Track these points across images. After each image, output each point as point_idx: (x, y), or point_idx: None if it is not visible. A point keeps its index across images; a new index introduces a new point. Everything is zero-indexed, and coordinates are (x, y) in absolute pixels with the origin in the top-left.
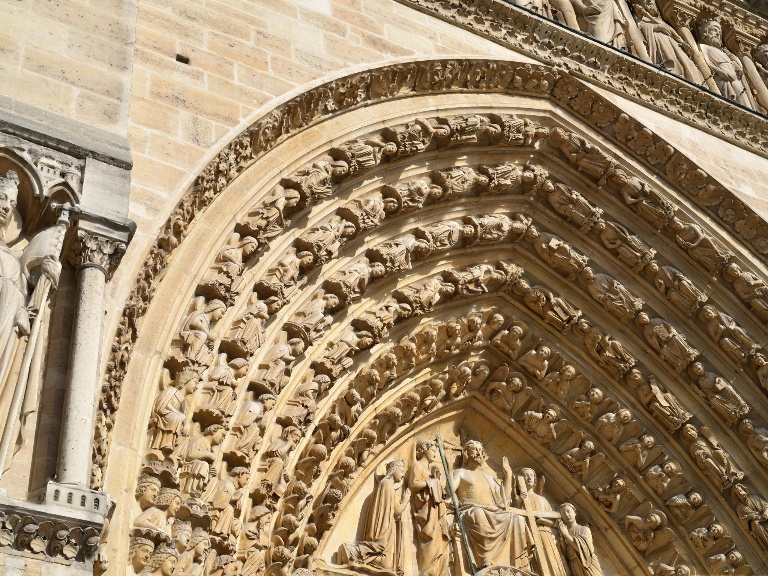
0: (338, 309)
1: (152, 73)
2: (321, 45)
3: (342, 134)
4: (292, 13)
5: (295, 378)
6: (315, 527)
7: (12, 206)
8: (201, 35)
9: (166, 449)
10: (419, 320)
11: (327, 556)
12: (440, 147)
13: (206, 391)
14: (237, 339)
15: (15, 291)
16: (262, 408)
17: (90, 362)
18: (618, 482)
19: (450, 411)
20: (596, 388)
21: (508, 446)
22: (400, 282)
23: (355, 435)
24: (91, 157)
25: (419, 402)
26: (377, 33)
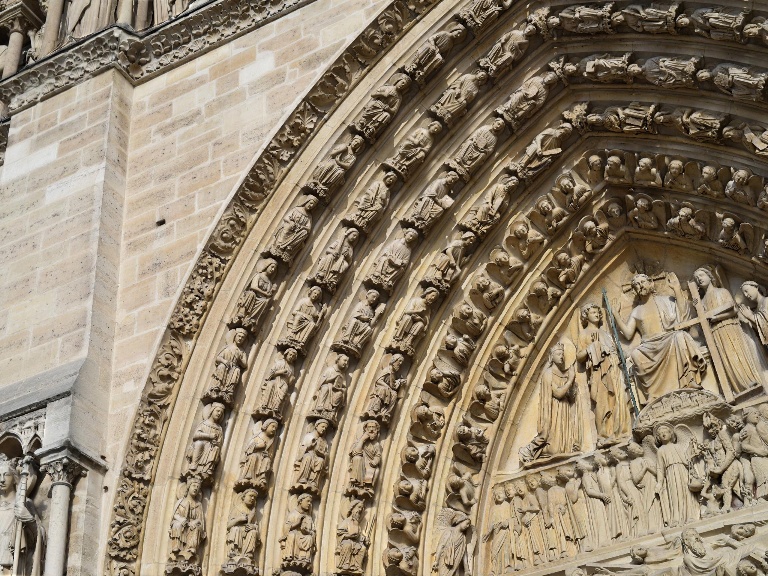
0: (388, 293)
1: (140, 256)
2: (264, 110)
3: (305, 170)
4: (242, 97)
5: (369, 374)
6: (455, 466)
7: (8, 476)
8: (174, 188)
9: (174, 552)
10: (507, 224)
11: (515, 463)
12: (420, 87)
13: (241, 465)
14: (261, 407)
15: (3, 541)
16: (316, 435)
17: (51, 559)
18: (765, 244)
19: (611, 259)
20: (704, 167)
21: (682, 255)
22: (458, 215)
23: (486, 360)
24: (49, 402)
25: (545, 289)
26: (313, 49)
